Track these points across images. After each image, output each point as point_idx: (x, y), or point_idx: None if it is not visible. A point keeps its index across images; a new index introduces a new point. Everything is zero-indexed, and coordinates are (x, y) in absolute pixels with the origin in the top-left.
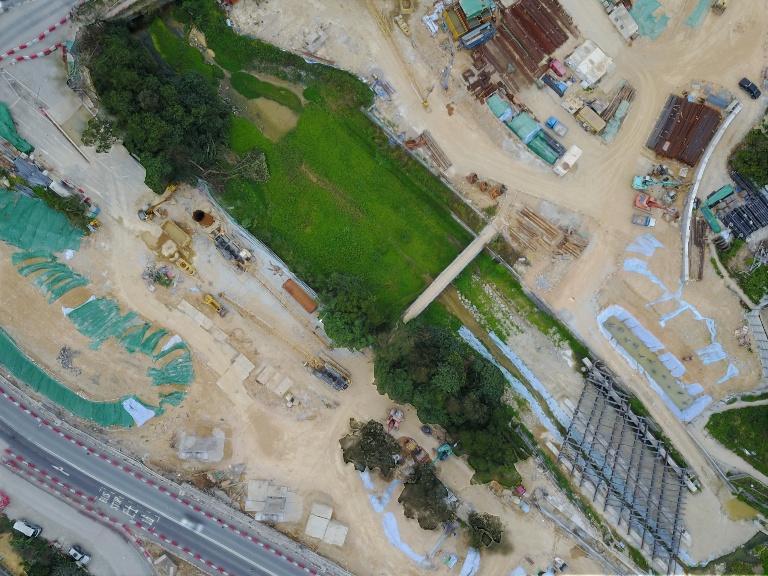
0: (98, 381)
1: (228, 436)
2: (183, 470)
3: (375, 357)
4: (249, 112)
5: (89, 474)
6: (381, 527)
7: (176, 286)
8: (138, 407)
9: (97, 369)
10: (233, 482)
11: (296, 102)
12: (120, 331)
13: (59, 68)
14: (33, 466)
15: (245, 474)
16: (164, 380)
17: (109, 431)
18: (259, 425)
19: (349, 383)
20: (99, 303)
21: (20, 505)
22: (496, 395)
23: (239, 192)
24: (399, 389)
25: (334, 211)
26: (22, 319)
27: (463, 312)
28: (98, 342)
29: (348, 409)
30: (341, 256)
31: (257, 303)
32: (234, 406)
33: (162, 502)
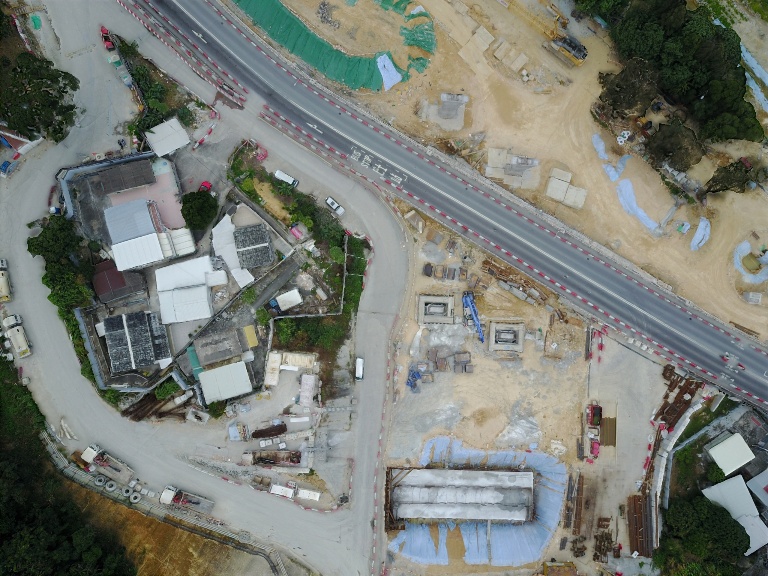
0: (355, 36)
1: (468, 106)
2: (426, 137)
3: (610, 31)
4: None
5: (341, 133)
6: (616, 195)
7: None
8: (389, 67)
9: (355, 23)
10: (473, 150)
11: None
12: None
13: None
14: (290, 121)
15: (485, 142)
16: (414, 42)
17: (358, 94)
18: (499, 95)
19: (587, 54)
20: None
21: (277, 159)
22: (736, 58)
23: None
24: (649, 41)
25: None
26: None
27: (688, 0)
28: None
29: (580, 87)
30: None
31: None
32: (475, 75)
33: (409, 162)
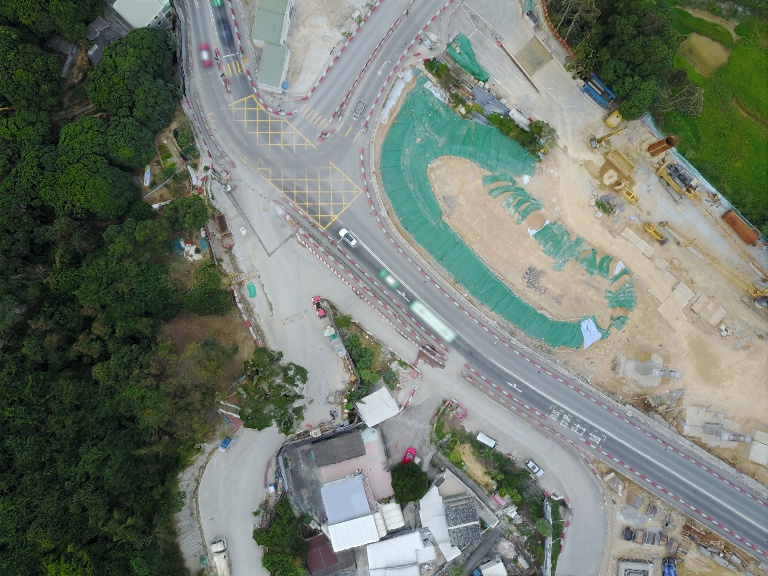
0: (560, 301)
1: (666, 362)
2: (622, 393)
3: None
4: (681, 47)
5: (540, 392)
6: None
7: (617, 214)
8: (592, 328)
9: (562, 289)
10: (670, 407)
11: (729, 38)
12: (576, 254)
13: (514, 1)
14: (491, 381)
15: (683, 399)
16: (617, 303)
17: (557, 352)
18: (698, 352)
19: None
20: (552, 227)
21: (477, 418)
22: None
23: (675, 125)
24: None
25: (766, 146)
26: (491, 239)
27: None
28: (561, 263)
29: None
30: None
31: (693, 234)
32: (675, 332)
33: (608, 422)
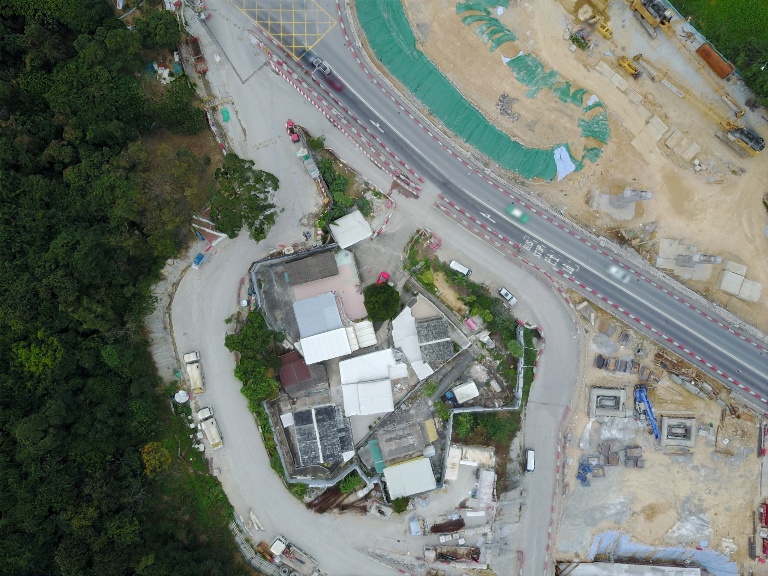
0: (534, 128)
1: None
2: (596, 226)
3: None
4: None
5: (514, 222)
6: None
7: (591, 49)
8: (565, 158)
9: (535, 115)
10: (643, 240)
11: None
12: (550, 84)
13: None
14: (464, 211)
15: (656, 233)
16: (590, 133)
17: (531, 184)
18: (671, 185)
19: None
20: (526, 59)
21: (450, 248)
22: None
23: None
24: None
25: None
26: (464, 66)
27: None
28: (534, 90)
29: (752, 177)
30: (746, 28)
31: None
32: (648, 165)
33: (581, 253)
